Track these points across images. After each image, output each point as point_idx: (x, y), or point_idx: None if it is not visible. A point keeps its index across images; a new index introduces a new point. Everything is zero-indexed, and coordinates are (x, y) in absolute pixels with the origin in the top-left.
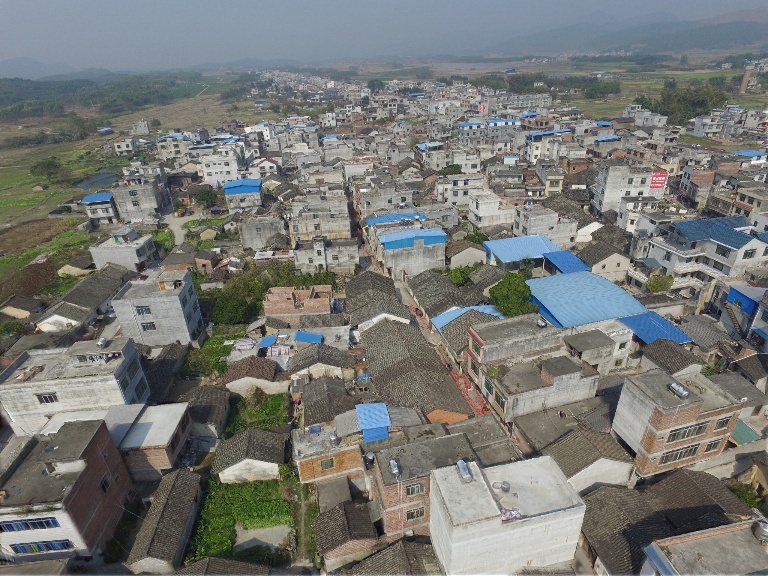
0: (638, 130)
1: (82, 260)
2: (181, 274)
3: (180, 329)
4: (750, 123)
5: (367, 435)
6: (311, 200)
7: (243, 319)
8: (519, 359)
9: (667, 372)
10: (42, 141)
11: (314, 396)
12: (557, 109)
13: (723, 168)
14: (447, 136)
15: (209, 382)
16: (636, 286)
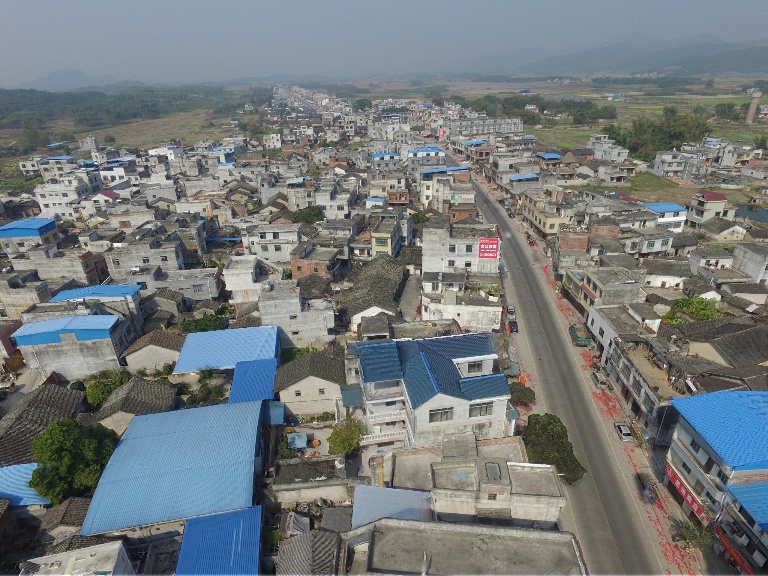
0: (583, 166)
1: None
2: None
3: None
4: (727, 160)
5: None
6: (34, 257)
7: None
8: None
9: None
10: None
11: None
12: (511, 137)
13: (598, 232)
14: None
15: None
16: None
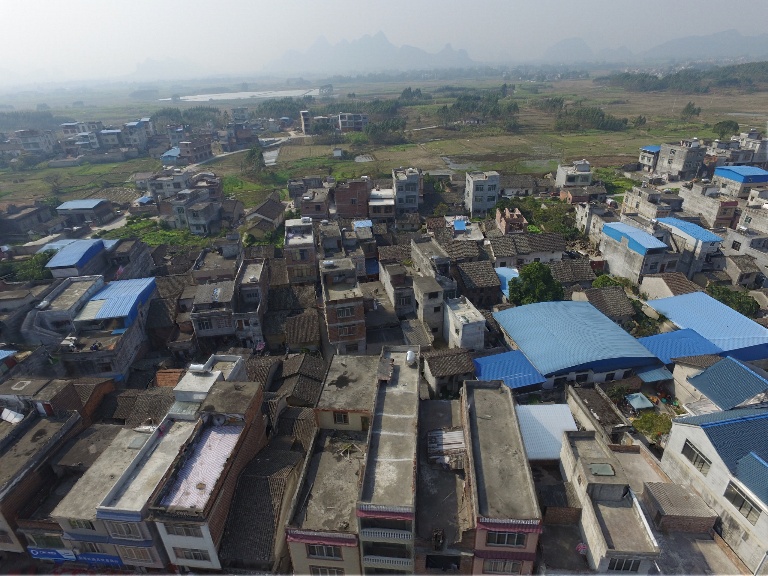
0: None
1: None
2: (492, 174)
3: None
4: None
5: None
6: (695, 190)
7: None
8: None
9: None
10: None
11: None
12: None
13: None
14: None
15: None
16: None
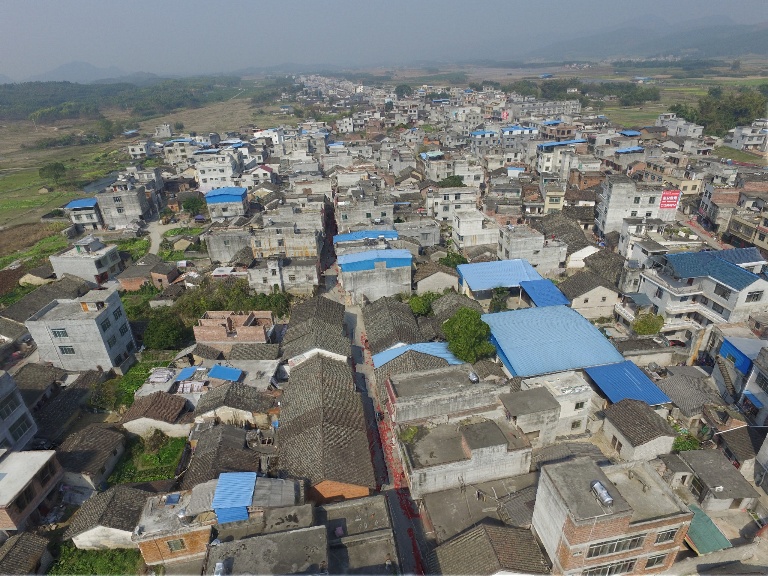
0: (668, 141)
1: (46, 269)
2: (106, 294)
3: (100, 354)
4: None
5: (221, 515)
6: (283, 213)
7: (175, 344)
8: (442, 419)
9: (629, 443)
10: (69, 143)
11: (205, 448)
12: (583, 117)
13: (749, 187)
14: (461, 144)
15: (116, 417)
16: (624, 324)
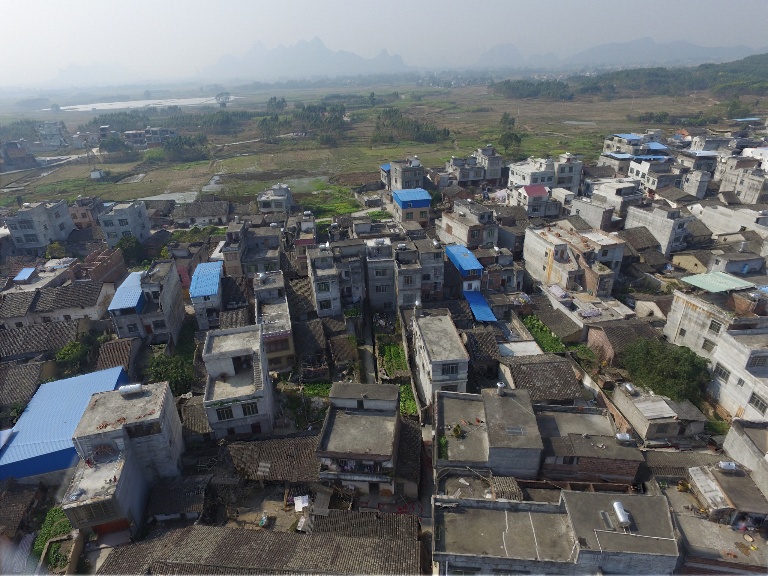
0: None
1: None
2: (121, 207)
3: None
4: None
5: None
6: None
7: None
8: None
9: None
10: (659, 120)
11: None
12: None
13: None
14: None
15: None
16: None
